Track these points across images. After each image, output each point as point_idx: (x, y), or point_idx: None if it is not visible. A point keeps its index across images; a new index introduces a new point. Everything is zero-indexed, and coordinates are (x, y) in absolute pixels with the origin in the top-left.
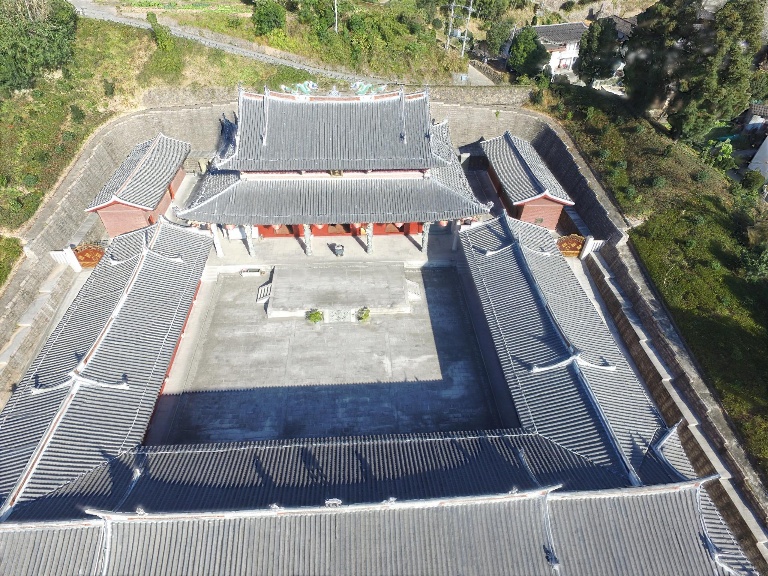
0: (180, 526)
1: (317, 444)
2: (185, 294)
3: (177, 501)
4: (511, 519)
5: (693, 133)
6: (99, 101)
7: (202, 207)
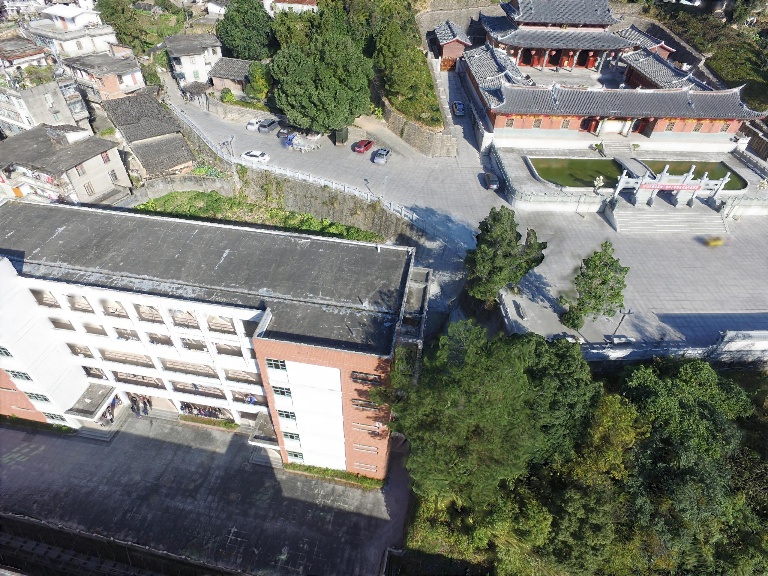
0: (574, 91)
1: None
2: None
3: None
4: (677, 97)
5: (738, 18)
6: (412, 4)
7: (506, 38)
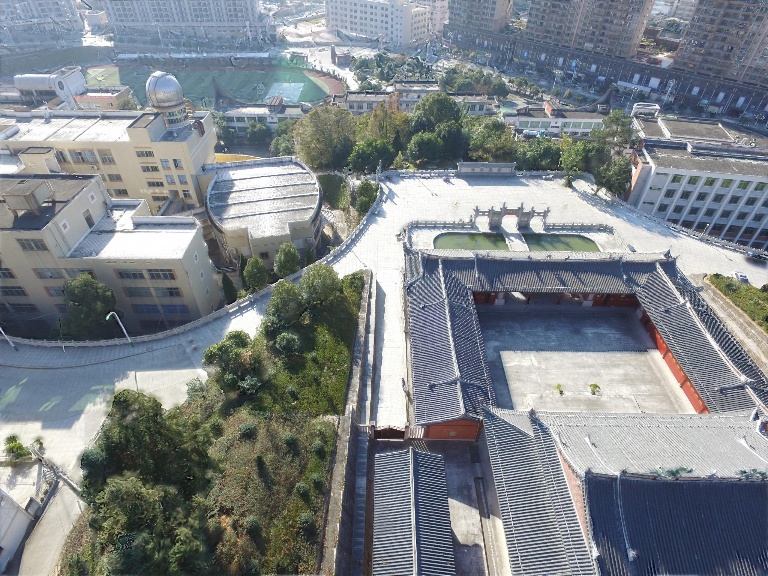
0: None
1: (561, 287)
2: (688, 365)
3: (603, 267)
4: None
5: None
6: None
7: None
